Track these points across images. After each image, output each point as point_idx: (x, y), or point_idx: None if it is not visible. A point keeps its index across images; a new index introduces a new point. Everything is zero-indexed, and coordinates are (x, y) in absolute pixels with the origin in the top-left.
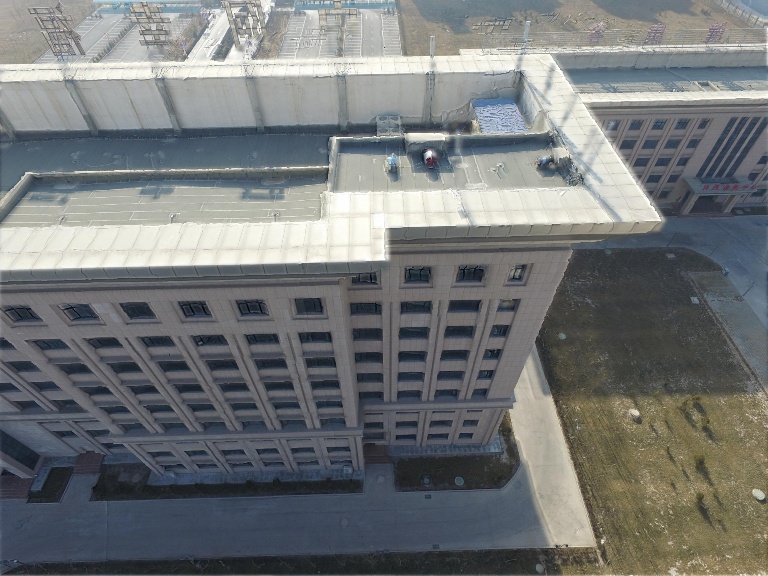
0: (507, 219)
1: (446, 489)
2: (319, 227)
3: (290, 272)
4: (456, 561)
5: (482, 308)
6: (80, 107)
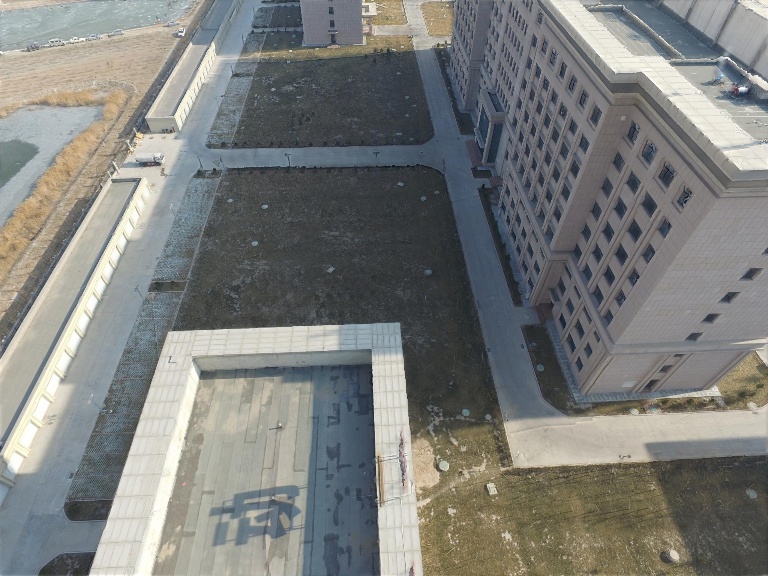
0: (685, 108)
1: (531, 358)
2: (628, 55)
3: (592, 57)
4: (482, 361)
5: (653, 214)
6: (693, 2)
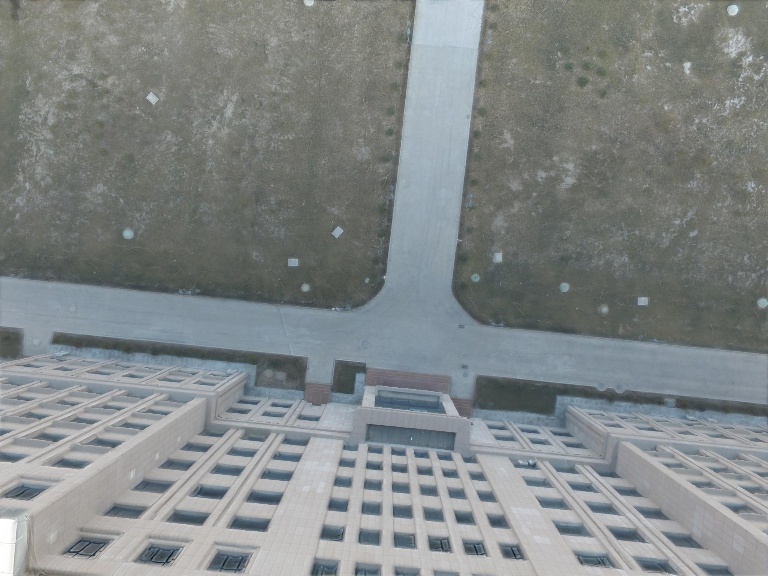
0: None
1: None
2: None
3: None
4: None
5: None
6: None
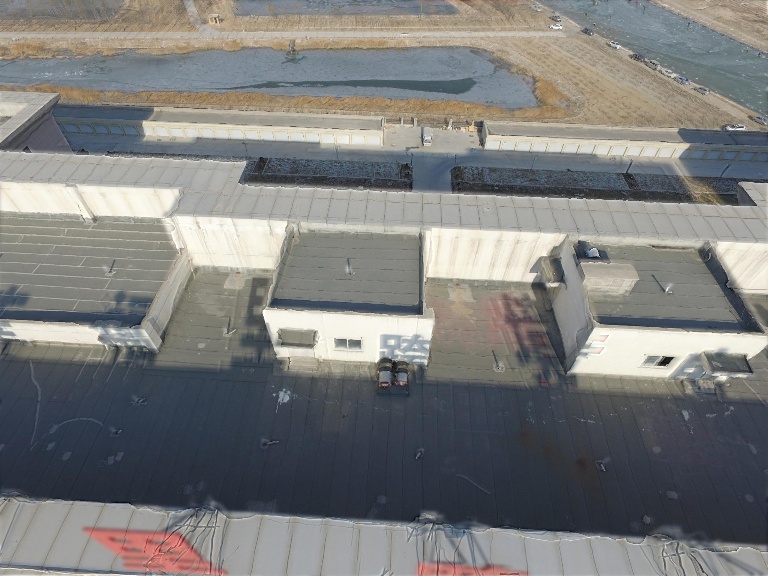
0: None
1: None
2: None
3: None
4: None
5: None
6: None
